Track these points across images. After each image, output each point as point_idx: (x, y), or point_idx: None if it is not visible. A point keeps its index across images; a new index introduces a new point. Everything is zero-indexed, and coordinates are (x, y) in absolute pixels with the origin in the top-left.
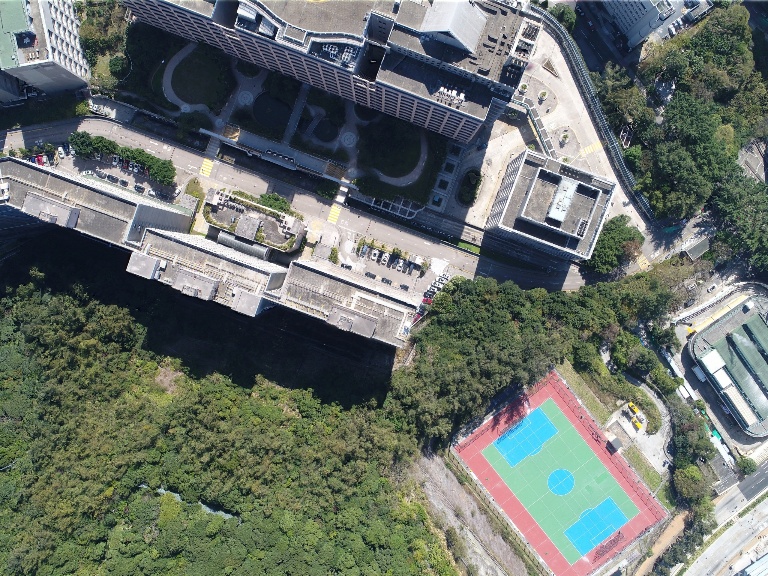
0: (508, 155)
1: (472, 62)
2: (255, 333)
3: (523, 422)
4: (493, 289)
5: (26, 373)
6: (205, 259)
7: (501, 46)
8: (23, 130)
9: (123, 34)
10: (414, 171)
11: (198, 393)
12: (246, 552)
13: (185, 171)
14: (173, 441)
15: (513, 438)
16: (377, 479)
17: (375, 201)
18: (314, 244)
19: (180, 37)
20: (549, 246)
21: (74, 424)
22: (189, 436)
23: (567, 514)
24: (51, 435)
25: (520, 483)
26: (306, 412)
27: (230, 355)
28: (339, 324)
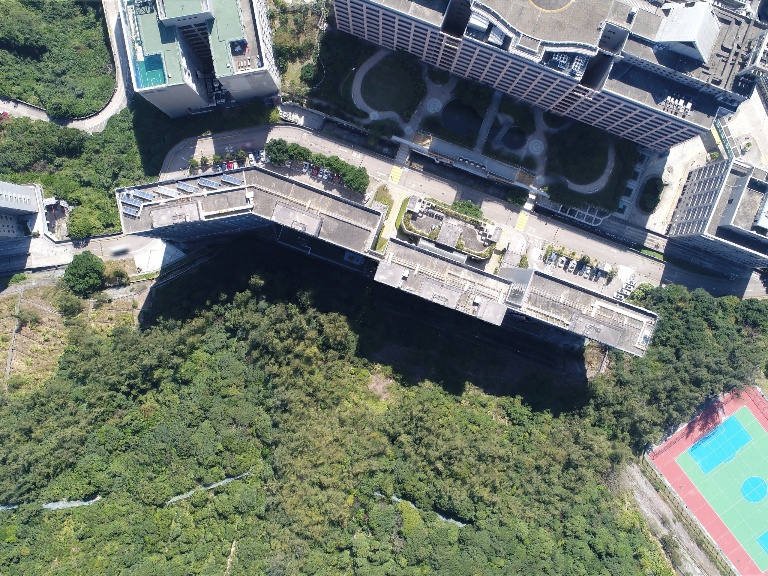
0: (689, 162)
1: (704, 72)
2: (455, 340)
3: (717, 429)
4: (687, 297)
5: (250, 380)
6: (446, 268)
7: (734, 56)
8: (214, 137)
9: (314, 41)
10: (601, 178)
11: (421, 401)
12: (486, 560)
13: (374, 178)
14: (400, 449)
15: (707, 445)
16: (595, 487)
17: (562, 208)
18: (502, 251)
19: (371, 44)
20: (750, 254)
21: (307, 432)
22: (416, 444)
23: (760, 521)
24: (289, 443)
25: (713, 490)
26: (518, 420)
27: (437, 362)
28: (588, 333)
